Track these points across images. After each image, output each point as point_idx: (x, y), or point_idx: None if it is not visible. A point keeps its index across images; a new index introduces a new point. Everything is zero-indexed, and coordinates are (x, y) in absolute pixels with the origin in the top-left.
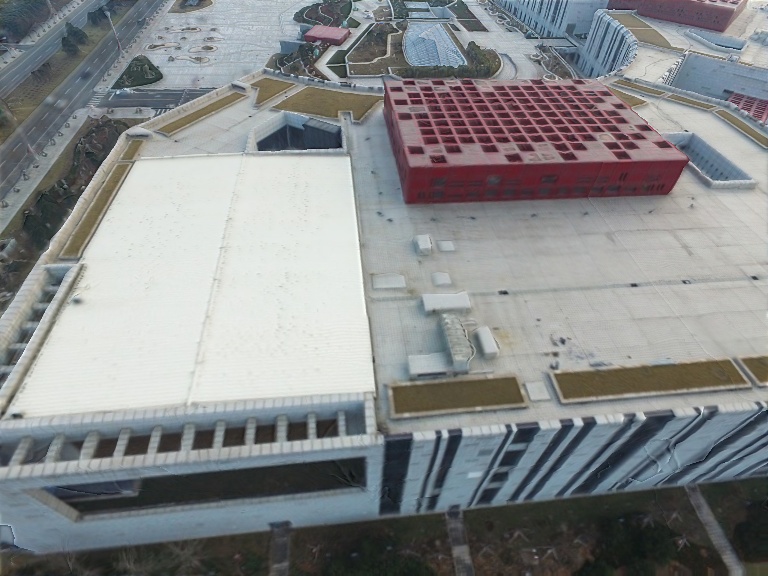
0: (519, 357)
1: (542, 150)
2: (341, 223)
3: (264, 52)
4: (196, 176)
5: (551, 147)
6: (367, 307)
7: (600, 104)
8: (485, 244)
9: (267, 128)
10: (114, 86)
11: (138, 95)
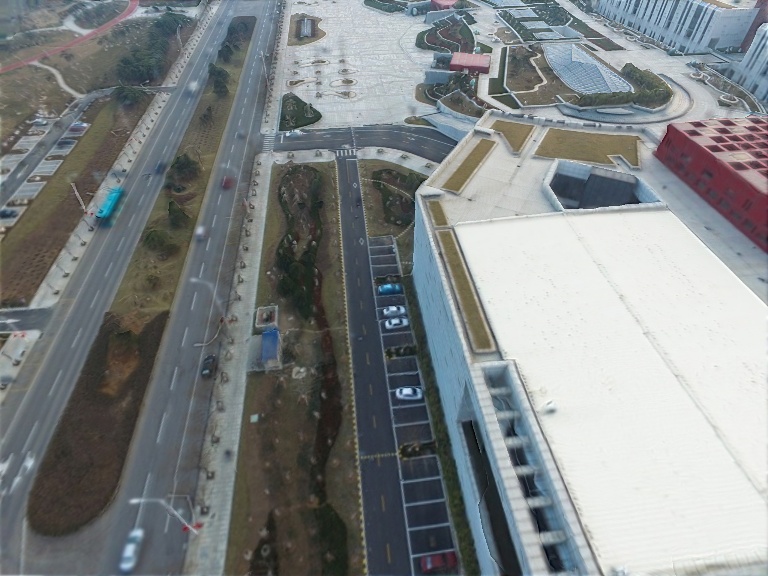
0: None
1: None
2: (739, 295)
3: (406, 83)
4: (535, 243)
5: None
6: None
7: None
8: None
9: (550, 179)
10: (281, 128)
11: (307, 136)
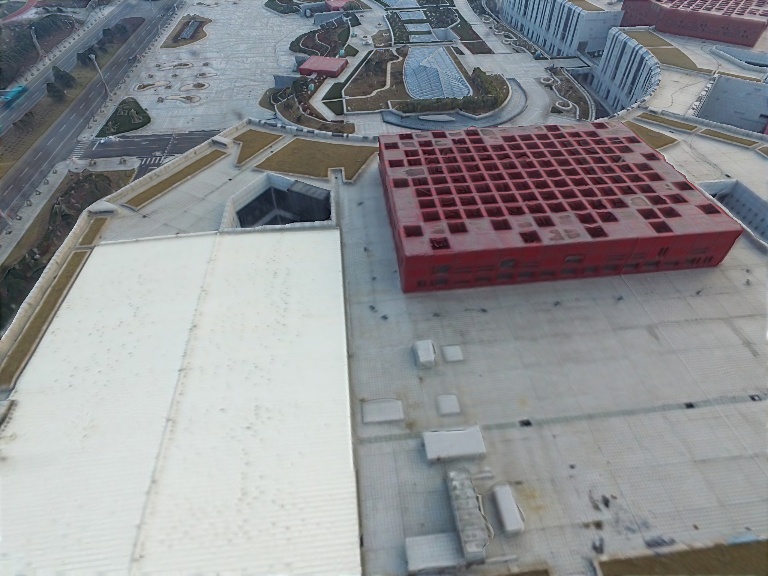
0: (550, 531)
1: (564, 224)
2: (326, 326)
3: (258, 87)
4: (161, 265)
5: (575, 219)
6: (354, 455)
7: (628, 155)
8: (500, 349)
9: (248, 194)
10: (99, 134)
11: (123, 143)
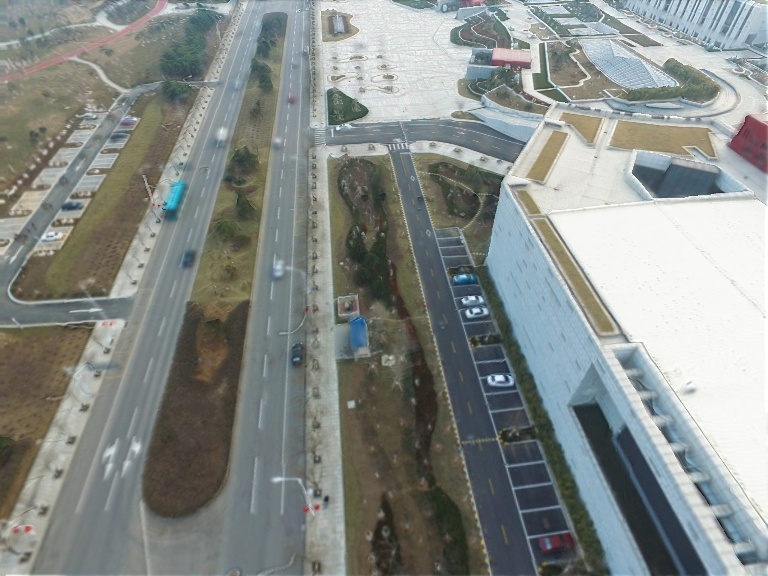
0: None
1: None
2: None
3: (447, 78)
4: (634, 230)
5: None
6: None
7: None
8: None
9: None
10: (330, 122)
11: (357, 130)
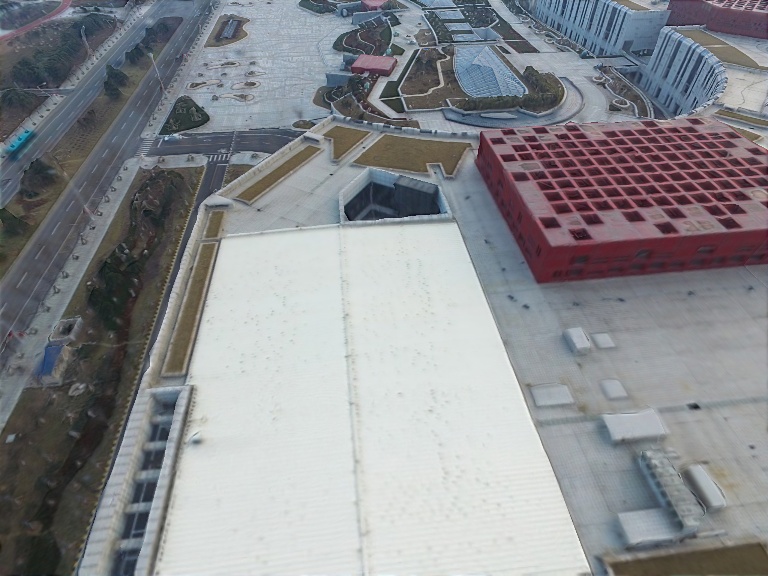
0: (750, 507)
1: (695, 216)
2: (473, 314)
3: (309, 86)
4: (293, 257)
5: (704, 211)
6: (540, 436)
7: (733, 150)
8: (648, 336)
9: (354, 189)
10: (162, 131)
11: (187, 140)
